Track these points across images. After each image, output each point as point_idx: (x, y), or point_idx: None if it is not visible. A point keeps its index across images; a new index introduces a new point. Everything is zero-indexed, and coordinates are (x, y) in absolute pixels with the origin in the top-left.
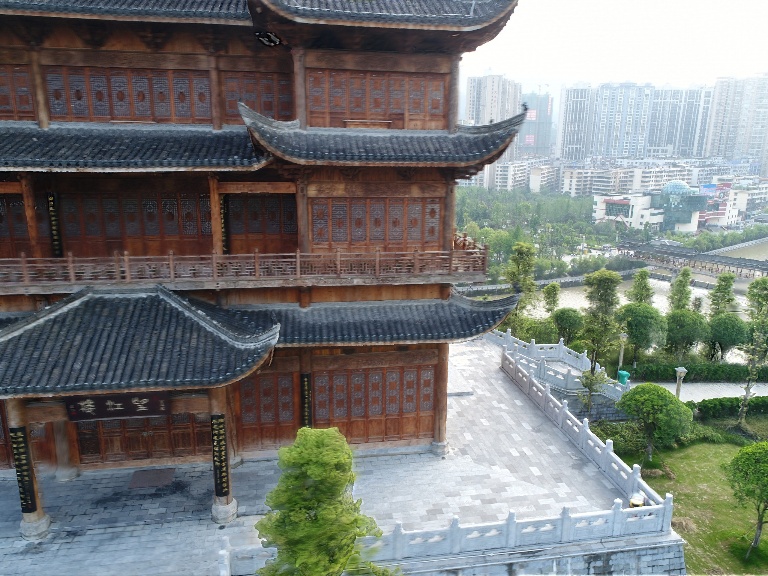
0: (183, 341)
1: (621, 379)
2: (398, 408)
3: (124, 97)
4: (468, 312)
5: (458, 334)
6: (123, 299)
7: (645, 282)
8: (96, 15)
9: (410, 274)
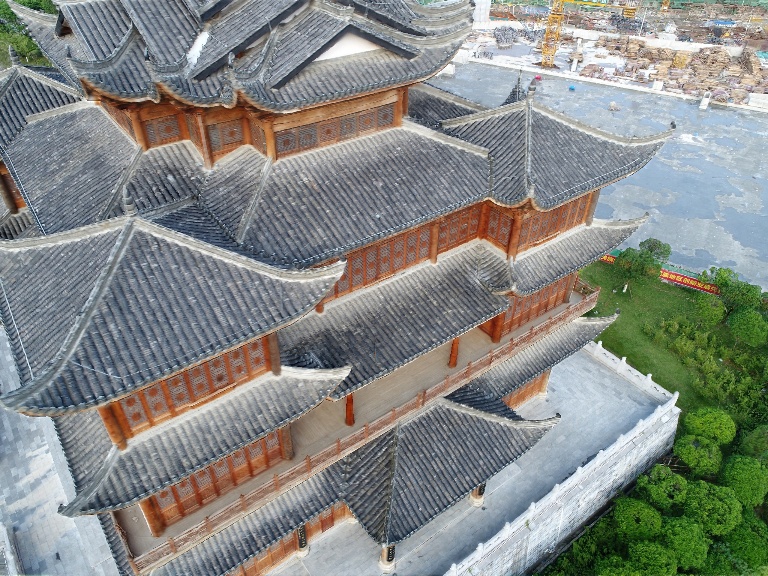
0: None
1: None
2: None
3: None
4: None
5: None
6: None
7: None
8: None
9: None
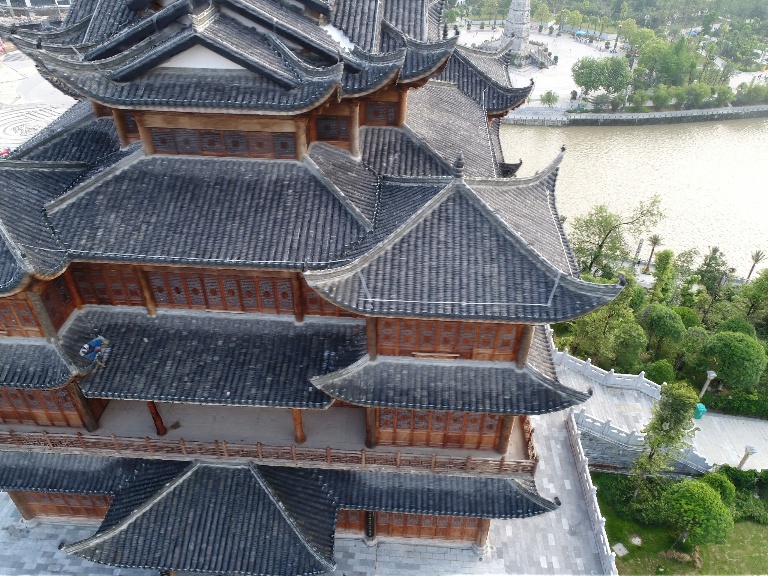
0: (267, 528)
1: (696, 412)
2: (447, 523)
3: (216, 293)
4: (514, 492)
5: (499, 516)
6: (223, 469)
7: (767, 284)
8: (185, 265)
9: (462, 470)
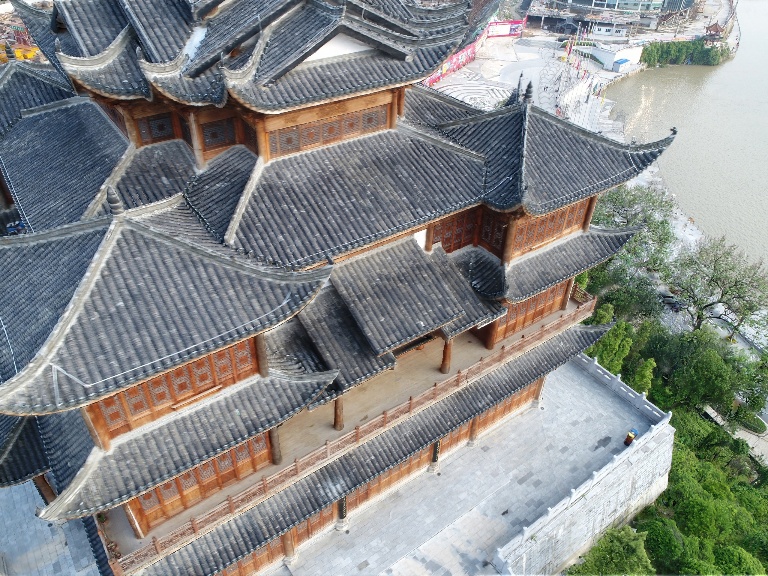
0: None
1: None
2: None
3: None
4: None
5: None
6: None
7: None
8: None
9: None
